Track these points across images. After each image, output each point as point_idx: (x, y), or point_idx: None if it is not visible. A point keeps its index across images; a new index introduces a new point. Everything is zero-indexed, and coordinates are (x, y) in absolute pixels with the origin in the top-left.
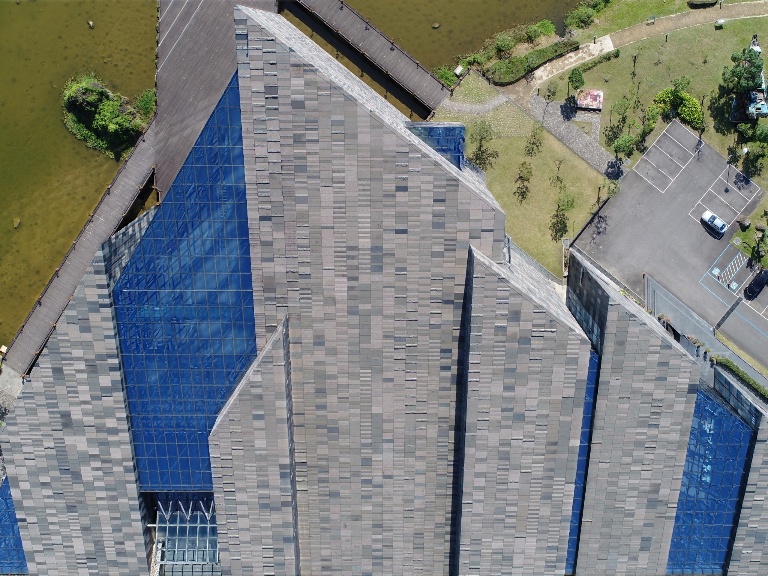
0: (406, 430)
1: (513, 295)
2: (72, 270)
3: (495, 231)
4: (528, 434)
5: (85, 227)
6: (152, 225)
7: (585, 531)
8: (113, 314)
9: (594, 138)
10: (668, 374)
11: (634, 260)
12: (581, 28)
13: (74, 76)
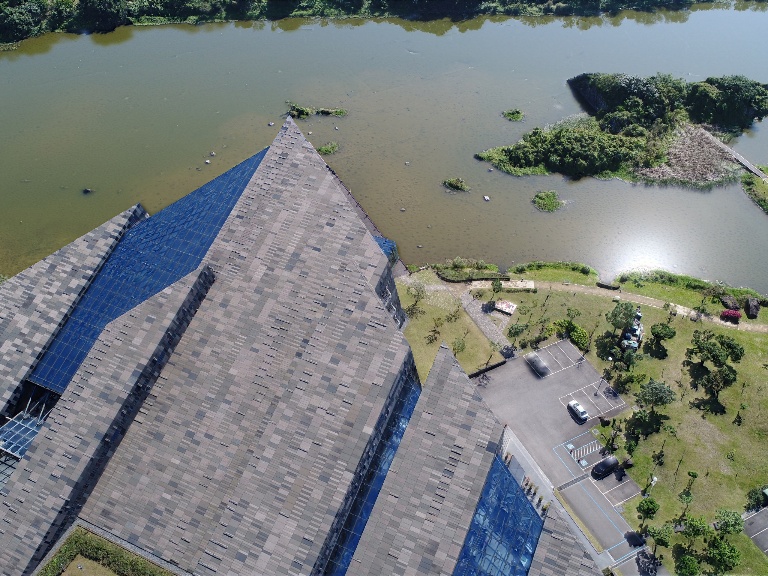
0: (245, 397)
1: (367, 290)
2: None
3: (378, 268)
4: (333, 407)
5: None
6: (175, 204)
7: (350, 573)
8: (113, 246)
9: (500, 329)
10: (473, 425)
11: (501, 413)
12: (516, 273)
13: None
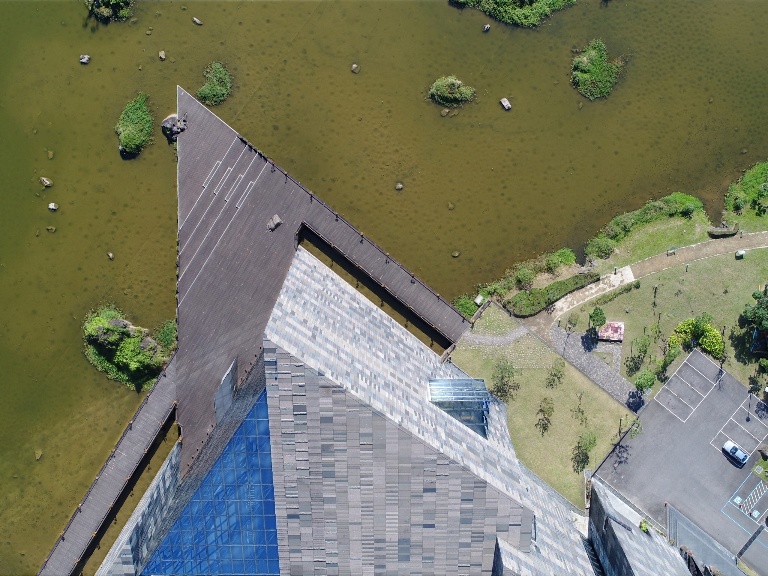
0: None
1: None
2: (95, 505)
3: (522, 525)
4: None
5: (107, 462)
6: (180, 520)
7: None
8: None
9: (615, 368)
10: None
11: (656, 489)
12: (601, 258)
13: (94, 308)
